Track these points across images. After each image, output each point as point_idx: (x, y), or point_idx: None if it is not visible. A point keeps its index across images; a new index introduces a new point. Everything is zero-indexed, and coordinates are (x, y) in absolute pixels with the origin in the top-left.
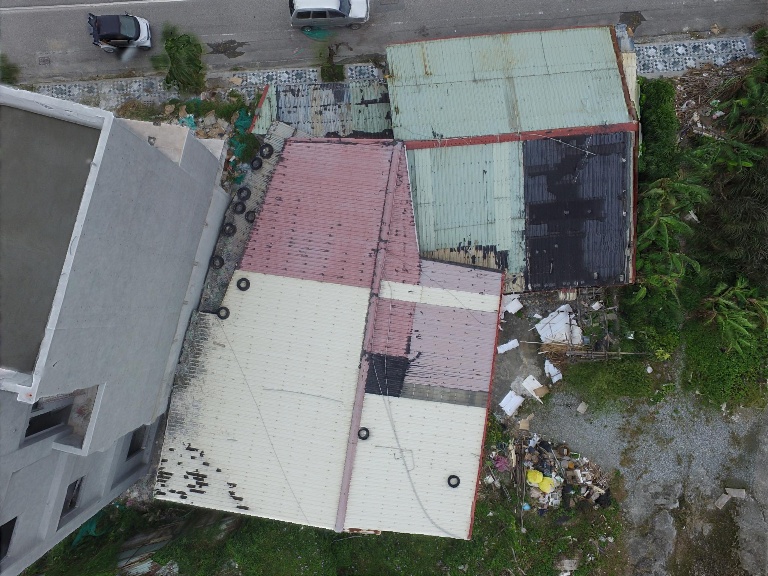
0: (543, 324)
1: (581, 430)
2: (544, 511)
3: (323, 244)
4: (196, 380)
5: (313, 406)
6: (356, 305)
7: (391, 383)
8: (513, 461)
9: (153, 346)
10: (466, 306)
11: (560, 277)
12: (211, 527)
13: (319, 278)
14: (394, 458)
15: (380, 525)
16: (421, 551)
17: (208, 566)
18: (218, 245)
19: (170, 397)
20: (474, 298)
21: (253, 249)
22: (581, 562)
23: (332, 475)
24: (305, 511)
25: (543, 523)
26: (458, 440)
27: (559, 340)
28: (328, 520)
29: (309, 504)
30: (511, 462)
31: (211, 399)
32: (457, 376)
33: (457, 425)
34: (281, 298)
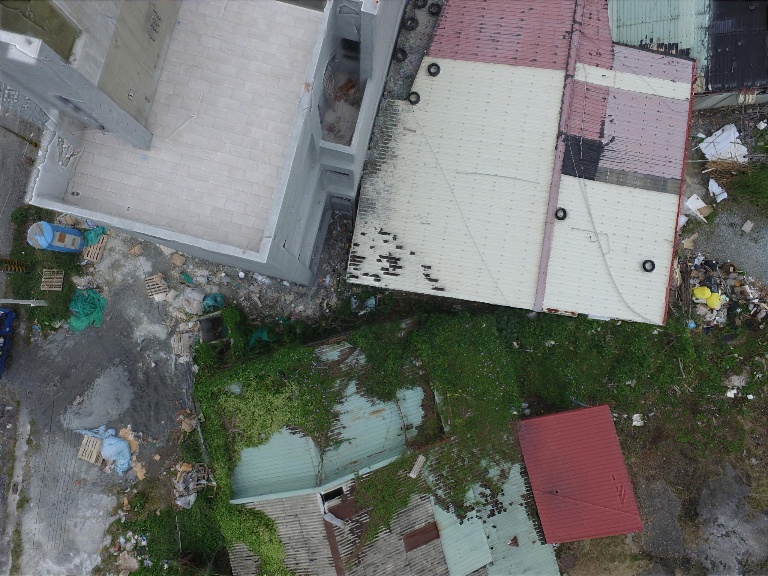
0: (707, 143)
1: (746, 249)
2: (710, 329)
3: (515, 28)
4: (386, 165)
5: (509, 188)
6: (551, 87)
7: (586, 166)
8: (678, 279)
9: (375, 95)
10: (658, 93)
11: (741, 77)
12: (392, 324)
13: (512, 62)
14: (590, 241)
15: (577, 307)
16: (586, 368)
17: (396, 356)
18: (400, 39)
19: (360, 183)
20: (666, 85)
21: (442, 36)
22: (749, 378)
23: (530, 255)
24: (503, 291)
25: (708, 342)
26: (652, 226)
27: (725, 157)
28: (527, 299)
29: (507, 284)
30: (676, 280)
31: (403, 184)
32: (650, 162)
33: (651, 211)
34: (473, 83)
